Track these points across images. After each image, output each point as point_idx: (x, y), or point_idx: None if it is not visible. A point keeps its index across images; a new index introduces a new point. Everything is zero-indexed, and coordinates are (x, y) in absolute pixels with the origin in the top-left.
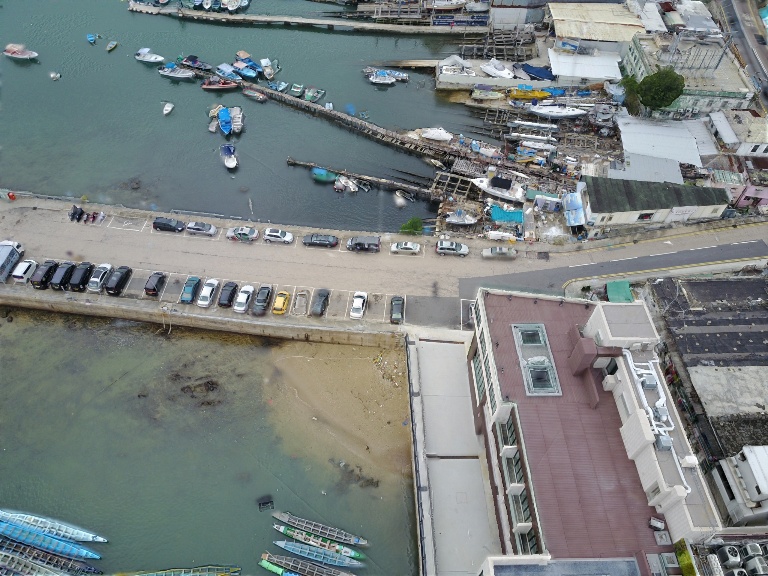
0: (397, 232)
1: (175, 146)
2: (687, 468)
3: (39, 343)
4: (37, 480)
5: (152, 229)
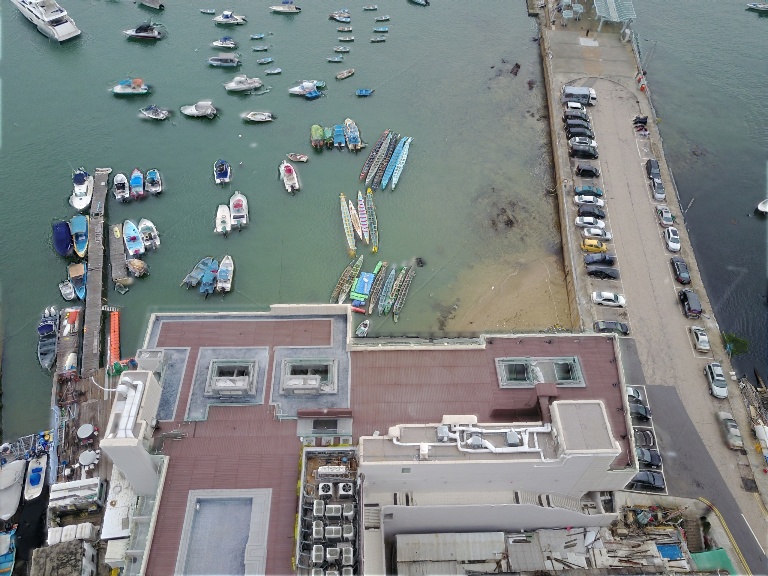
0: (745, 359)
1: (766, 169)
2: (419, 451)
3: (524, 136)
4: (429, 157)
5: (645, 163)
